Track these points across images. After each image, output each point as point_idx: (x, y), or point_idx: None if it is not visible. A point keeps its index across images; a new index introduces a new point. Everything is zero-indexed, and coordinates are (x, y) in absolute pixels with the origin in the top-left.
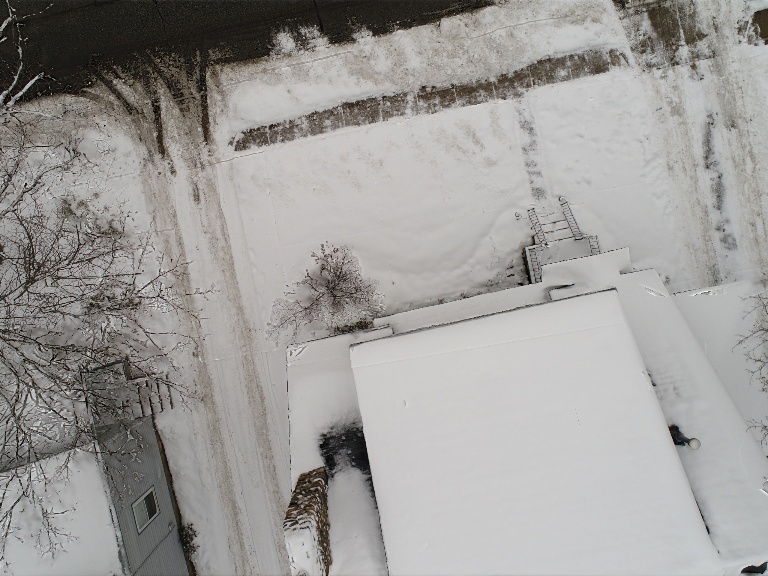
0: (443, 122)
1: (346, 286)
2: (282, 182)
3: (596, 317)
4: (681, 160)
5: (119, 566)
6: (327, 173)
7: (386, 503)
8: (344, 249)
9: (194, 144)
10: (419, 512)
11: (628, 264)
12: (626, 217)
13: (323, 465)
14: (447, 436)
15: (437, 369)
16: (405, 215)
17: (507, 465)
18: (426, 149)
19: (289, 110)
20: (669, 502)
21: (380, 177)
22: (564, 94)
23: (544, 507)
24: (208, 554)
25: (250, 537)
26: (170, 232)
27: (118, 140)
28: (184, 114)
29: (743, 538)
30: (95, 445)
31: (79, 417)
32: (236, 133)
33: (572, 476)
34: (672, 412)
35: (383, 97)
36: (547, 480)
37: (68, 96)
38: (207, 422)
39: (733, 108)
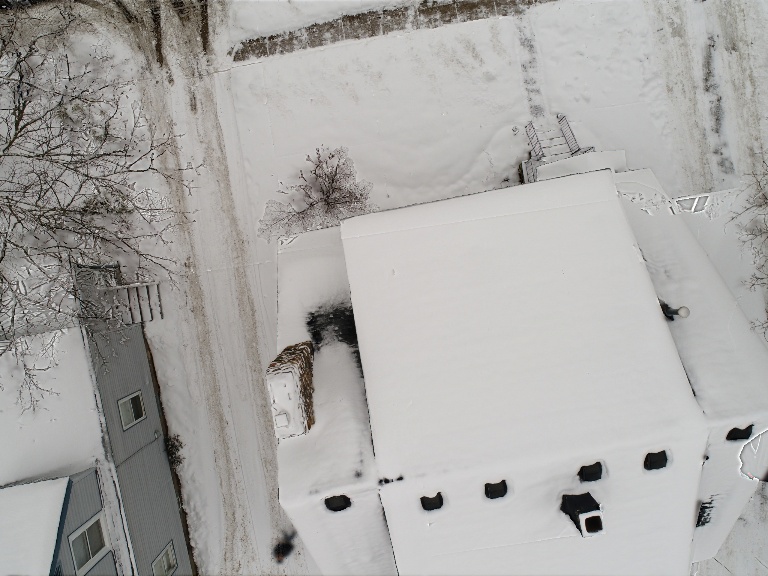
0: (443, 36)
1: (340, 195)
2: (280, 92)
3: (589, 194)
4: (681, 82)
5: (102, 451)
6: (325, 84)
7: (371, 364)
8: (339, 151)
9: (193, 53)
10: (404, 373)
11: (623, 165)
12: (624, 136)
13: (310, 339)
14: (435, 303)
15: (427, 241)
16: (402, 128)
17: (494, 330)
18: (425, 63)
19: (289, 20)
20: (656, 365)
21: (378, 90)
22: (565, 10)
23: (530, 369)
24: (194, 467)
25: (236, 451)
26: None
27: (117, 47)
28: (184, 23)
29: (729, 400)
30: (82, 329)
31: (65, 282)
32: (235, 43)
33: (559, 341)
34: (662, 289)
35: (384, 11)
36: (534, 344)
37: (68, 2)
38: (197, 334)
39: (734, 31)
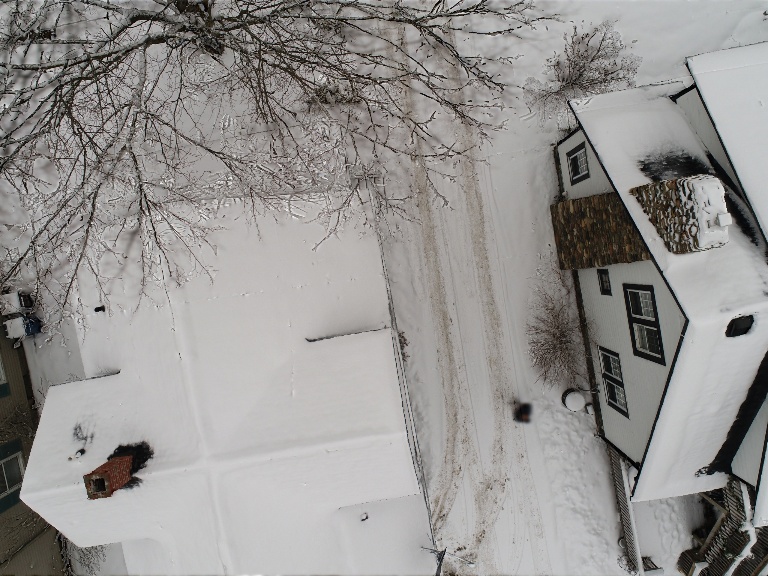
0: None
1: (588, 79)
2: None
3: None
4: None
5: (389, 319)
6: None
7: (758, 189)
8: (606, 25)
9: None
10: None
11: None
12: None
13: None
14: None
15: None
16: (644, 15)
17: None
18: None
19: None
20: None
21: None
22: None
23: None
24: (417, 366)
25: (460, 350)
26: (392, 31)
27: None
28: None
29: None
30: (369, 192)
31: None
32: None
33: None
34: None
35: None
36: None
37: None
38: (421, 229)
39: None
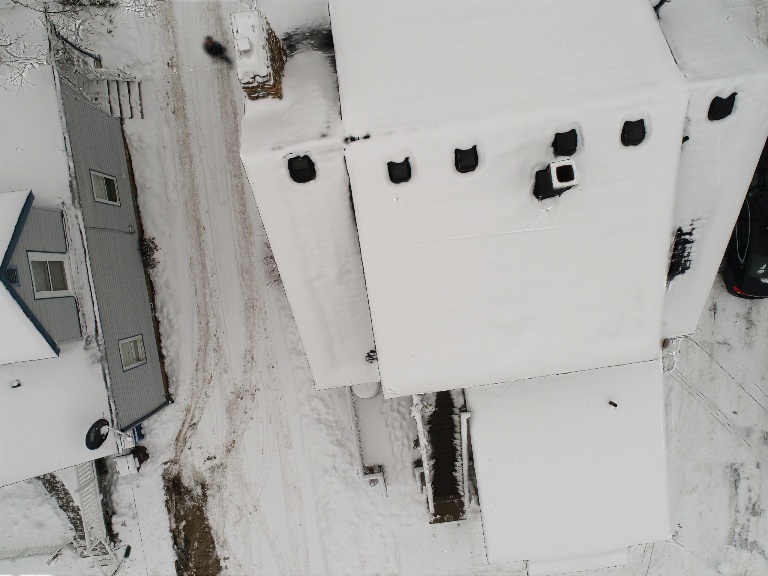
0: None
1: None
2: None
3: None
4: None
5: (69, 196)
6: None
7: (343, 41)
8: None
9: None
10: (377, 48)
11: None
12: None
13: None
14: None
15: None
16: None
17: (472, 11)
18: None
19: None
20: (638, 37)
21: None
22: None
23: (507, 43)
24: (168, 272)
25: (213, 258)
26: None
27: None
28: None
29: (712, 68)
30: (54, 69)
31: None
32: None
33: (539, 19)
34: None
35: None
36: (512, 22)
37: None
38: (177, 136)
39: None
